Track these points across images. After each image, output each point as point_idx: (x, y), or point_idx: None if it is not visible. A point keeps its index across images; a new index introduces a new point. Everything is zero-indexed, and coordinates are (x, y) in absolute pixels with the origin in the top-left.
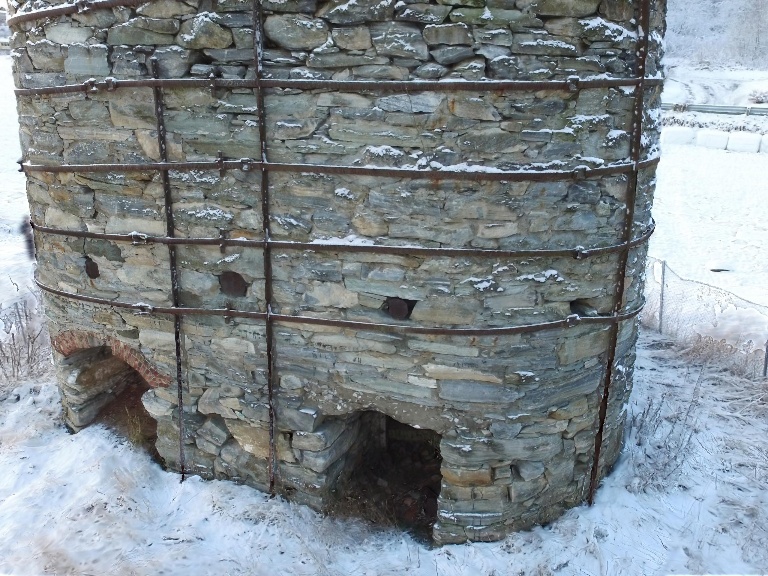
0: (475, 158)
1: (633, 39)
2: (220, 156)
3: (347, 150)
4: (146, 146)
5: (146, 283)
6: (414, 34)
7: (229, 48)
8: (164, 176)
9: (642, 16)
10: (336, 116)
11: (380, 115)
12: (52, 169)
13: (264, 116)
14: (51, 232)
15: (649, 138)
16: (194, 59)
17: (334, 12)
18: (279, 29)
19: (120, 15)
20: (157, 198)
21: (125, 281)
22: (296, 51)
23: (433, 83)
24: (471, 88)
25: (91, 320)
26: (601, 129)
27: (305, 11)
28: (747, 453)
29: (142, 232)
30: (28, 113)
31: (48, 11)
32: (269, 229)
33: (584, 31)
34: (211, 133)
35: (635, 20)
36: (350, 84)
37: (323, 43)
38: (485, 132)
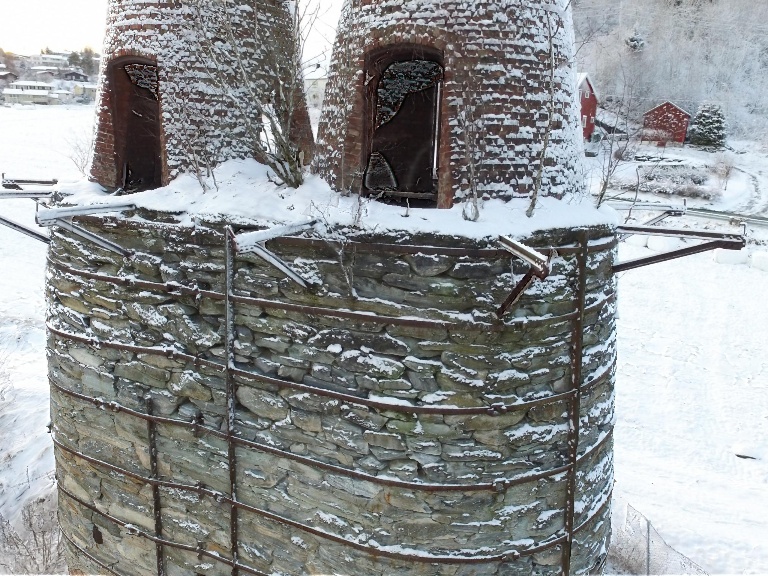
0: (409, 542)
1: (564, 432)
2: (199, 484)
3: (301, 508)
4: (142, 458)
5: (139, 562)
6: (356, 434)
7: (209, 401)
8: (154, 488)
9: (573, 412)
10: (293, 479)
11: (328, 489)
12: (70, 451)
13: (235, 463)
14: (68, 495)
15: (590, 498)
16: (182, 400)
17: (292, 399)
18: (248, 399)
19: (125, 356)
20: (149, 500)
21: (123, 554)
22: (262, 418)
23: (371, 477)
24: (404, 486)
25: (96, 572)
26: (531, 515)
27: (269, 390)
28: None
29: (137, 522)
30: (55, 398)
31: (71, 336)
32: (237, 552)
33: (510, 441)
34: (193, 462)
35: (567, 413)
36: (303, 460)
37: (283, 418)
38: (418, 521)
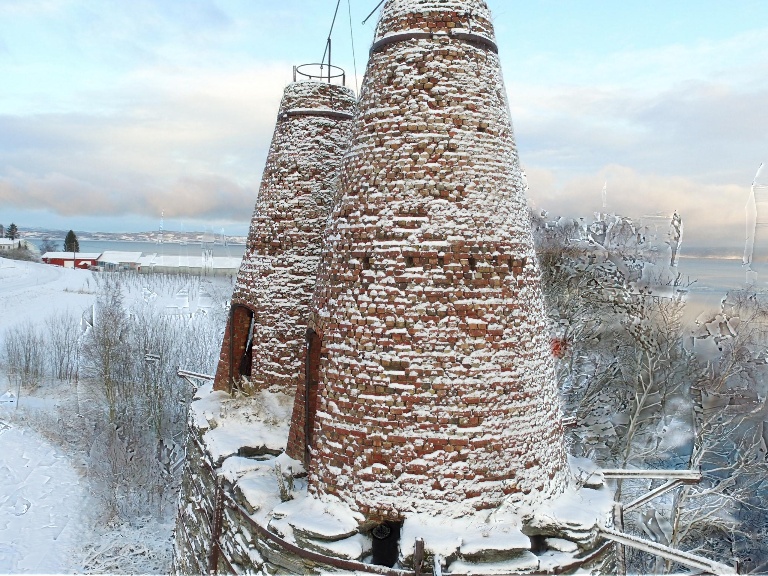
0: None
1: None
2: None
3: None
4: None
5: None
6: None
7: None
8: None
9: None
10: None
11: None
12: None
13: None
14: None
15: None
16: None
17: None
18: None
19: None
20: None
21: None
22: None
23: None
24: None
25: None
26: None
27: None
28: None
29: None
30: None
31: None
32: None
33: None
34: None
35: None
36: None
37: None
38: None
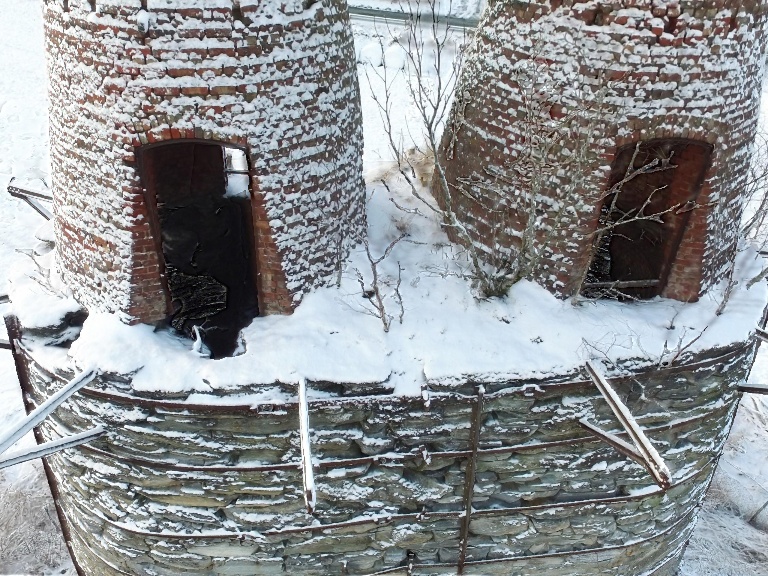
0: (637, 572)
1: None
2: None
3: None
4: None
5: None
6: (610, 522)
7: (427, 542)
8: None
9: None
10: None
11: None
12: None
13: None
14: None
15: None
16: None
17: None
18: (485, 529)
19: None
20: None
21: None
22: (497, 537)
23: (620, 547)
24: None
25: None
26: None
27: (511, 514)
28: (690, 546)
29: None
30: None
31: (195, 537)
32: None
33: None
34: None
35: None
36: None
37: (525, 530)
38: (646, 556)
